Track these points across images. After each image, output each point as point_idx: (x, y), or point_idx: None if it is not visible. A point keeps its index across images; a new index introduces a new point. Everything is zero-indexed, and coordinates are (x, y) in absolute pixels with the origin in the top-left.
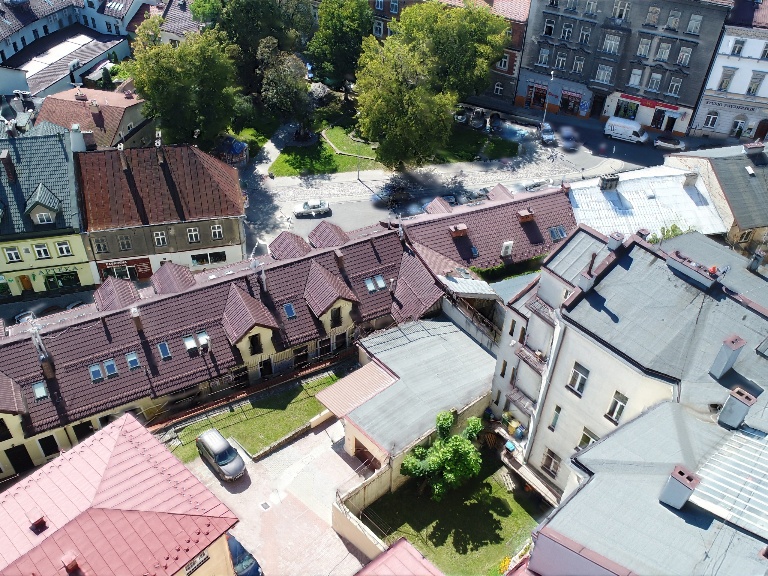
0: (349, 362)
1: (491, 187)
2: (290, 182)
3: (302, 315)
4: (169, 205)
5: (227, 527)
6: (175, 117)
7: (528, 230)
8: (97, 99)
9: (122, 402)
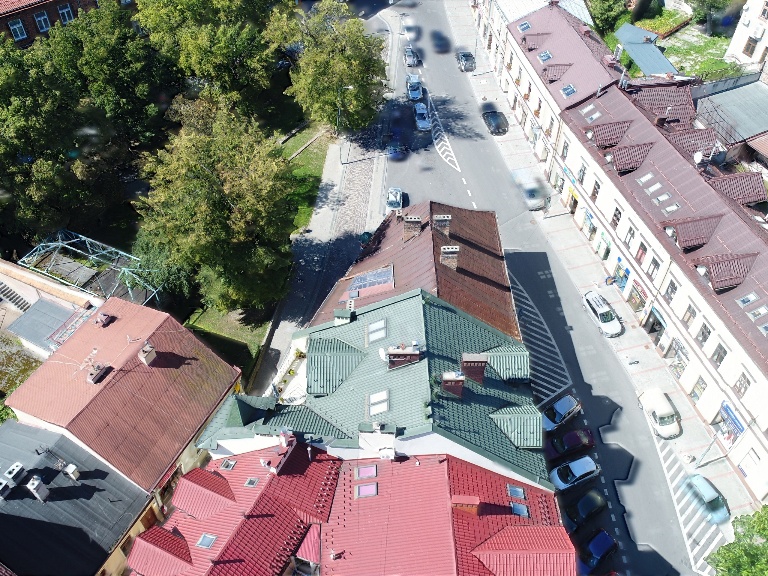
0: (720, 170)
1: (412, 79)
2: (325, 217)
3: (708, 166)
4: (489, 260)
5: None
6: None
7: (593, 39)
8: (105, 357)
9: None
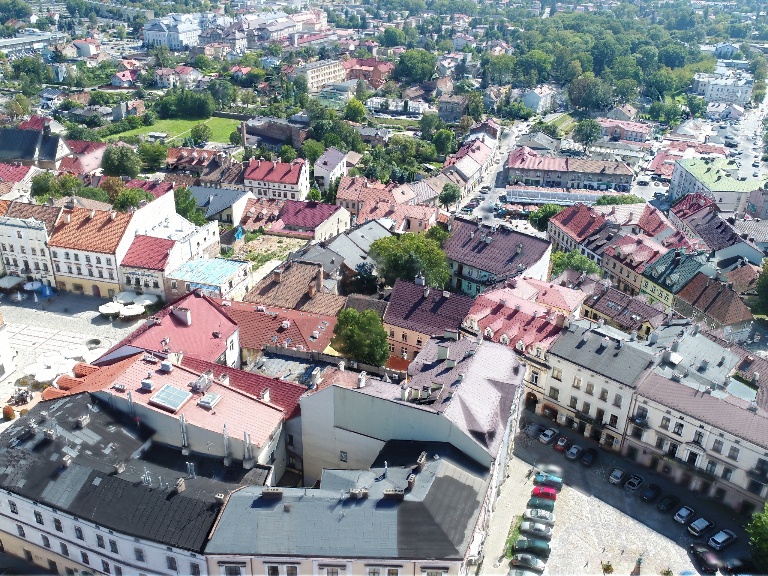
0: None
1: None
2: None
3: None
4: (706, 305)
5: (569, 310)
6: (765, 291)
7: None
8: None
9: (605, 314)
